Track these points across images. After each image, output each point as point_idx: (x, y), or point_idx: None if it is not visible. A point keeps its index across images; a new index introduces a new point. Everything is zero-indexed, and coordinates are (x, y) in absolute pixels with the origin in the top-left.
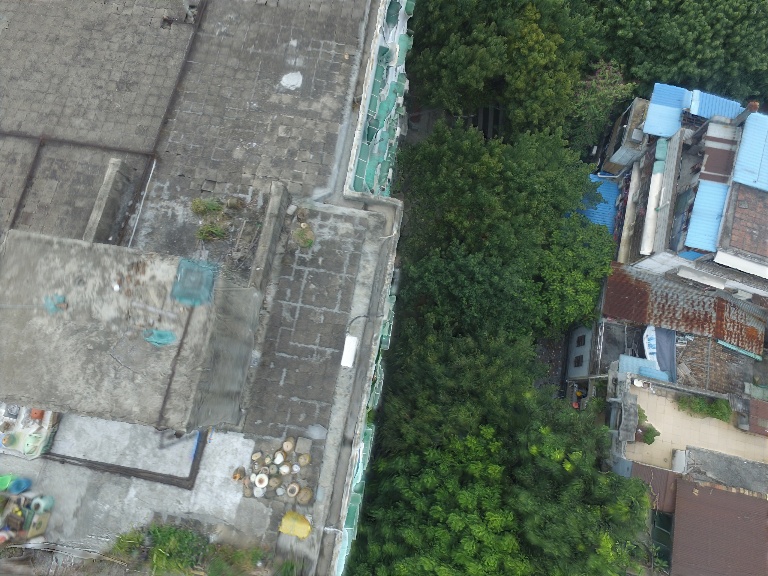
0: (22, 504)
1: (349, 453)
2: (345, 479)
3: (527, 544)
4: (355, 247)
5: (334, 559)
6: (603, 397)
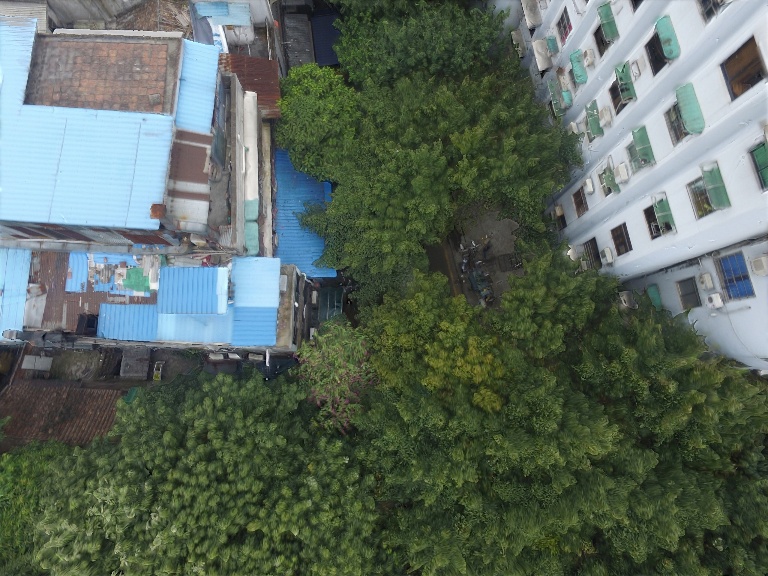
0: None
1: None
2: None
3: None
4: None
5: None
6: None
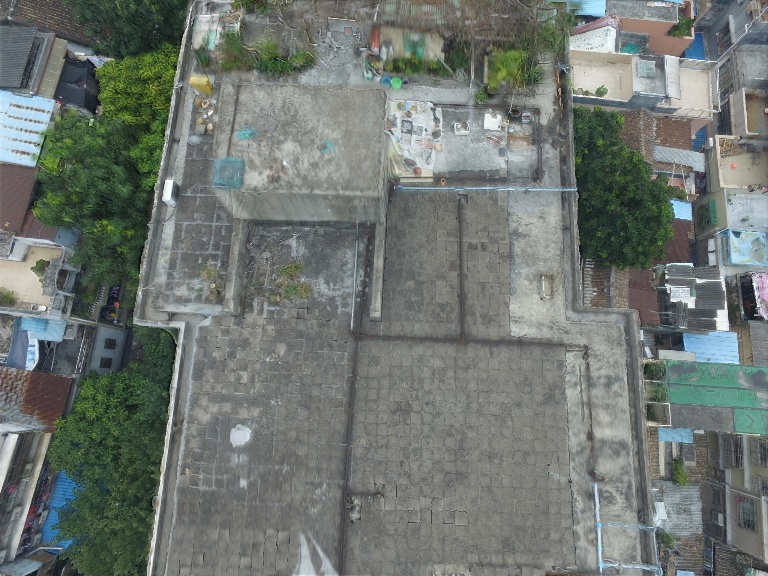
0: (374, 70)
1: (176, 135)
2: (178, 120)
3: (139, 173)
4: (172, 275)
5: (178, 73)
6: (83, 303)
